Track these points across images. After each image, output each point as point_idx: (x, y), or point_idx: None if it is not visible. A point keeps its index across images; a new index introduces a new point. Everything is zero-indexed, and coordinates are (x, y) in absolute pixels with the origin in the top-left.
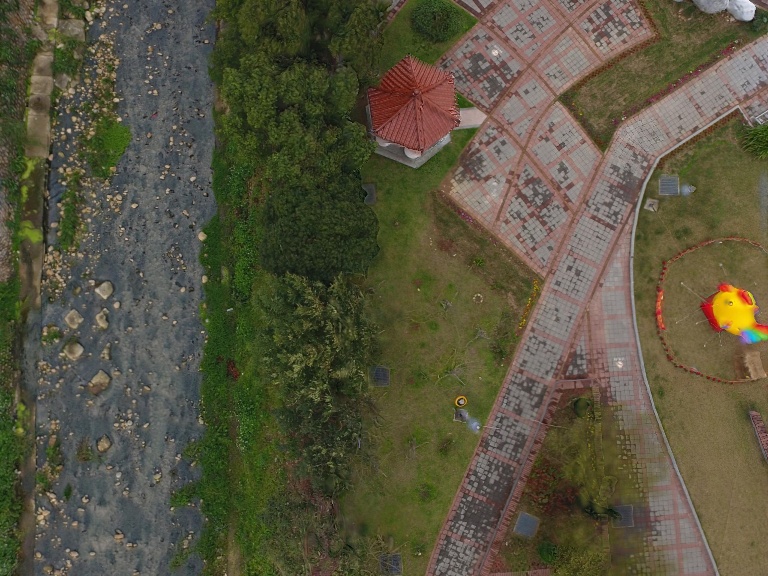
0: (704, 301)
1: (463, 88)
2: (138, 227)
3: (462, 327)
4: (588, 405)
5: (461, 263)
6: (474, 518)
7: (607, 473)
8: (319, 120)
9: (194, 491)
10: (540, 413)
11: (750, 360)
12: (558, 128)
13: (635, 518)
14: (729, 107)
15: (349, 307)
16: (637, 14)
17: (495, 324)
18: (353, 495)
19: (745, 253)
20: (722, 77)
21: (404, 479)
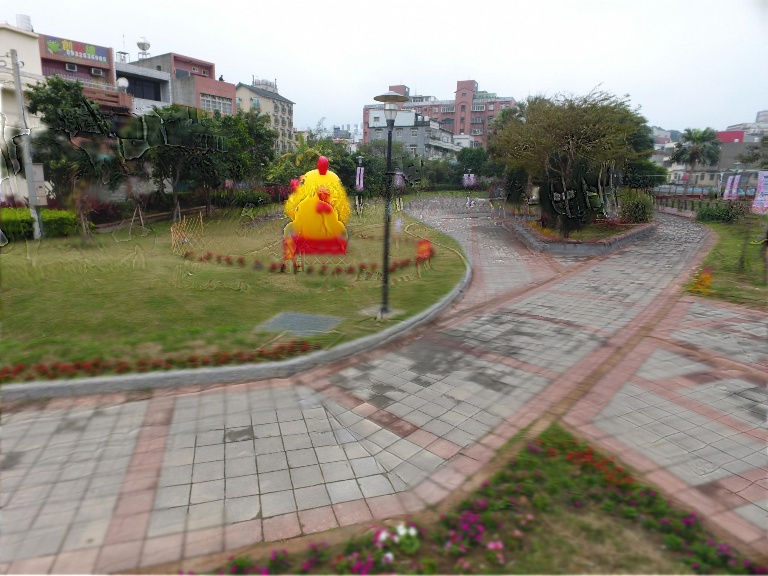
0: None
1: None
2: None
3: None
4: None
5: None
6: None
7: None
8: None
9: None
10: None
11: None
12: None
13: None
14: None
15: None
16: None
17: (758, 267)
18: None
19: None
20: None
21: None
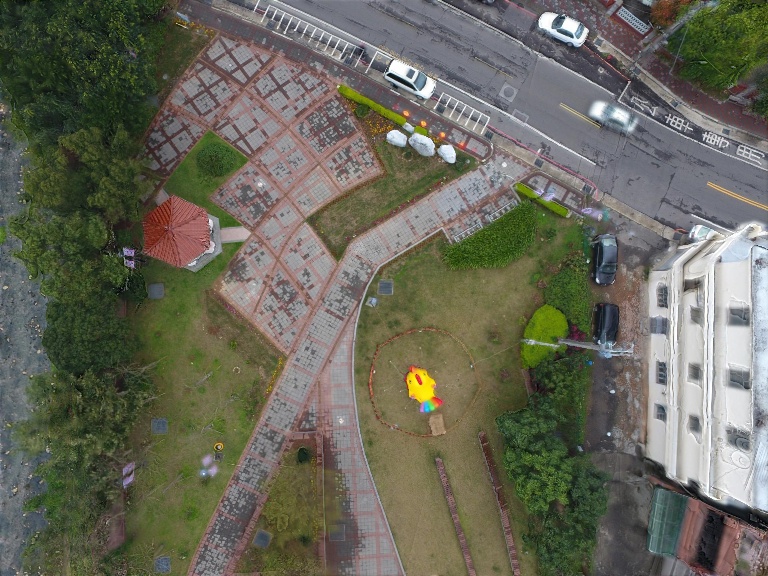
0: (403, 376)
1: (234, 212)
2: (8, 304)
3: (224, 391)
4: (305, 453)
5: (225, 344)
6: (226, 532)
7: (327, 501)
8: (77, 257)
9: (39, 503)
10: (279, 456)
11: (432, 421)
12: (305, 243)
13: (347, 534)
14: (436, 228)
15: (94, 392)
16: (370, 156)
17: (249, 389)
18: (136, 514)
19: (439, 339)
20: (433, 205)
21: (174, 503)
